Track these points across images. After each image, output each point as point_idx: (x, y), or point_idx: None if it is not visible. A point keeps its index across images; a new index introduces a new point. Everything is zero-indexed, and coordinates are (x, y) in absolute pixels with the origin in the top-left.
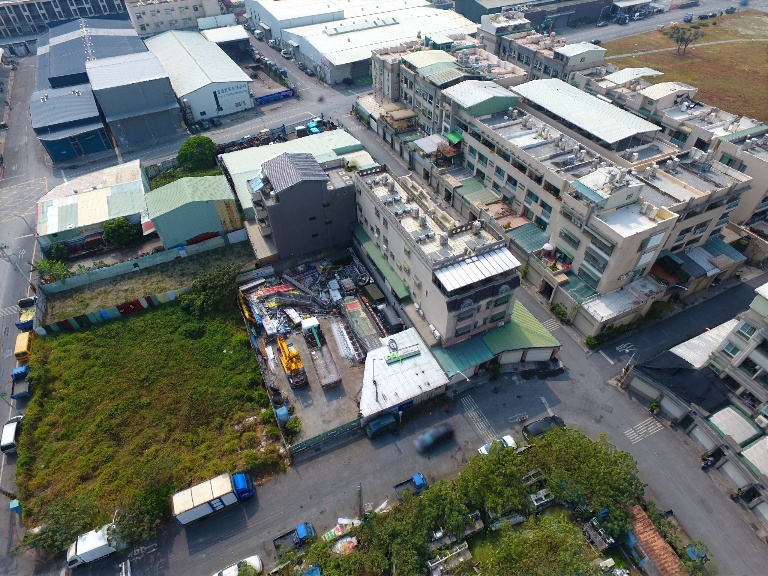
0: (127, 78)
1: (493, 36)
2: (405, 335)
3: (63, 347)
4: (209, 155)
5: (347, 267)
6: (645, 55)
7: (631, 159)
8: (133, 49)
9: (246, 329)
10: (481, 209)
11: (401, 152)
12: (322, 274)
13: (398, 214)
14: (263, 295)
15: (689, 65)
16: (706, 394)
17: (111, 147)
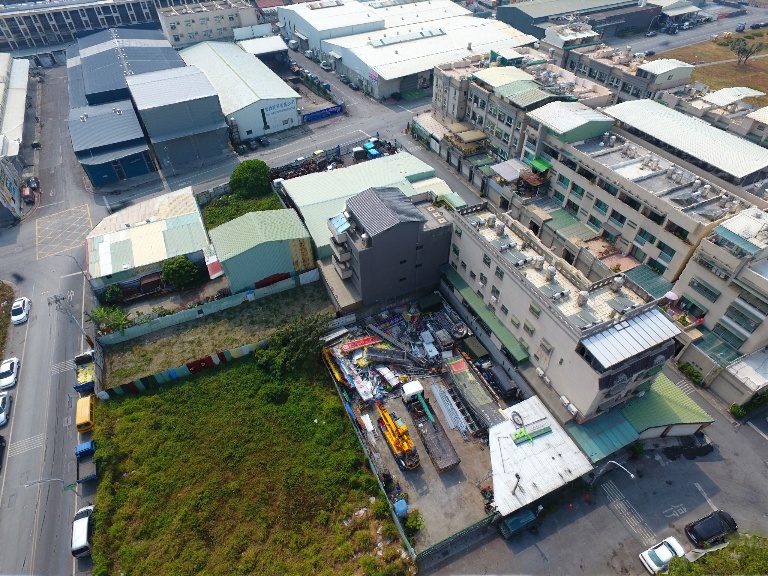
0: (174, 96)
1: (560, 50)
2: (528, 406)
3: (130, 415)
4: (264, 180)
5: (437, 314)
6: (704, 68)
7: (762, 196)
8: (169, 62)
9: (336, 392)
10: (581, 247)
11: (470, 177)
12: (410, 323)
13: (519, 265)
14: (350, 350)
15: (754, 79)
16: None
17: (154, 170)
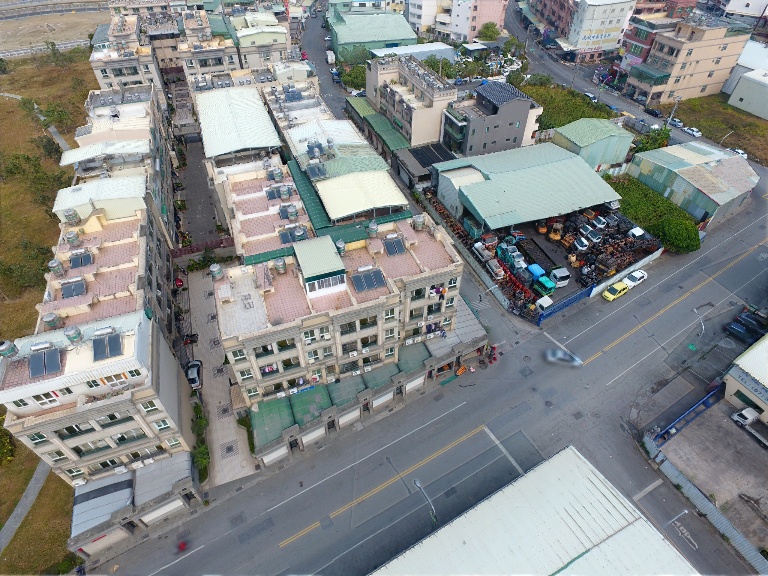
0: None
1: (154, 326)
2: None
3: None
4: None
5: None
6: None
7: None
8: None
9: None
10: None
11: None
12: None
13: None
14: None
15: None
16: None
17: None
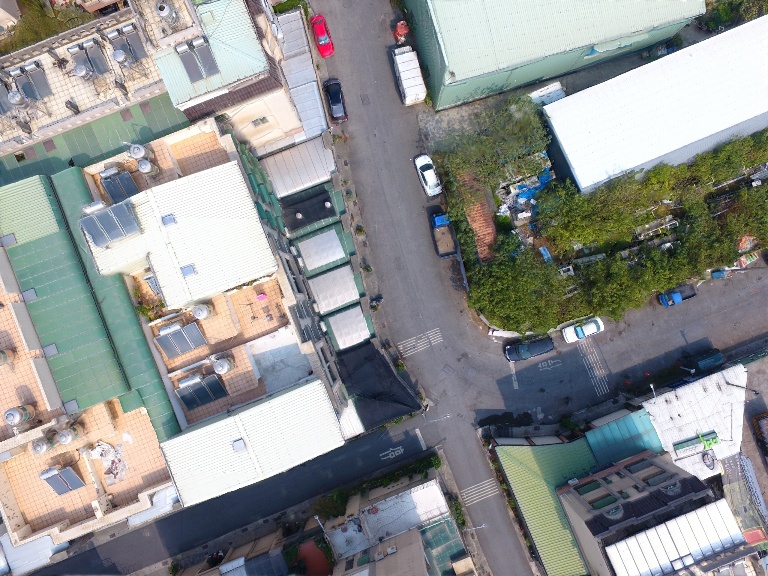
0: None
1: None
2: None
3: None
4: None
5: None
6: None
7: None
8: None
9: None
10: None
11: None
12: None
13: None
14: None
15: None
16: (361, 364)
17: None
